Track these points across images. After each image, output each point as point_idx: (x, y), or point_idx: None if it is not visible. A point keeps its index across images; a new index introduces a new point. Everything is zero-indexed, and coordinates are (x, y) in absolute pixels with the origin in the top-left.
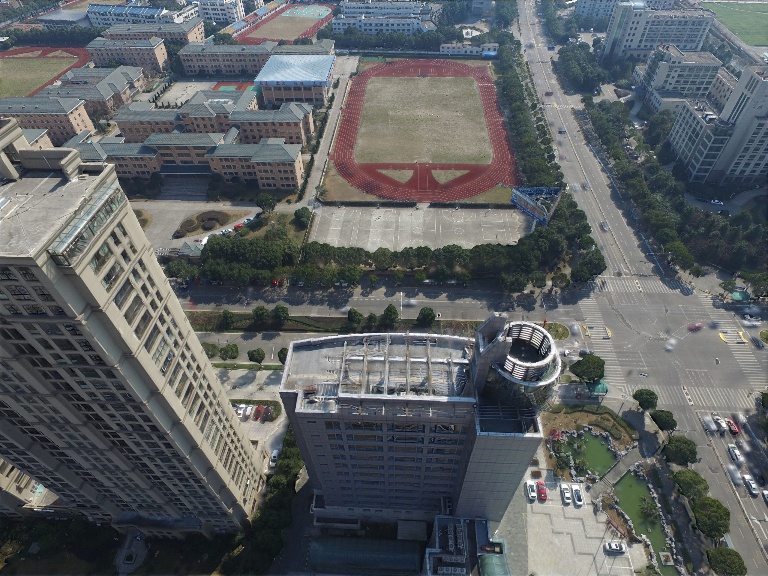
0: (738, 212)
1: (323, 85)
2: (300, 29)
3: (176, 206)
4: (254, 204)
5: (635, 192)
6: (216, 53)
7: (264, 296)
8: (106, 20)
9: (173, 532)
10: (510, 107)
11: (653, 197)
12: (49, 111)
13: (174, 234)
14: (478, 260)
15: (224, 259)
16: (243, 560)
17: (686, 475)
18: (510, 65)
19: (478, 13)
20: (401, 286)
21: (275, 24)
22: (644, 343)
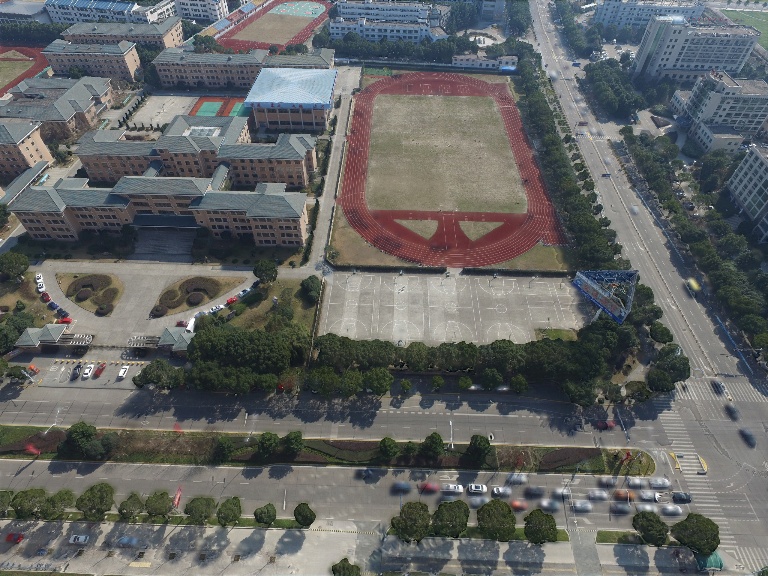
0: None
1: (325, 108)
2: (292, 30)
3: (154, 269)
4: (250, 267)
5: (704, 260)
6: (198, 63)
7: (269, 407)
8: (68, 14)
9: None
10: (541, 139)
11: (725, 267)
12: None
13: (152, 312)
14: (537, 364)
15: (217, 361)
16: None
17: None
18: (535, 85)
19: (488, 17)
20: (440, 392)
21: (263, 23)
22: (748, 480)
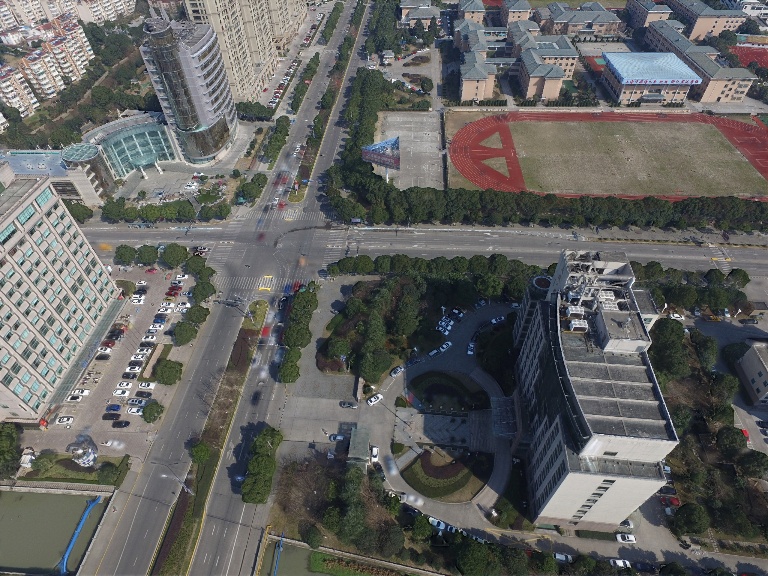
0: (453, 365)
1: None
2: None
3: (435, 70)
4: (440, 91)
5: None
6: (662, 34)
7: None
8: None
9: None
10: None
11: (456, 273)
12: (508, 5)
13: None
14: None
15: None
16: None
17: (172, 206)
18: None
19: None
20: None
21: None
22: (275, 234)
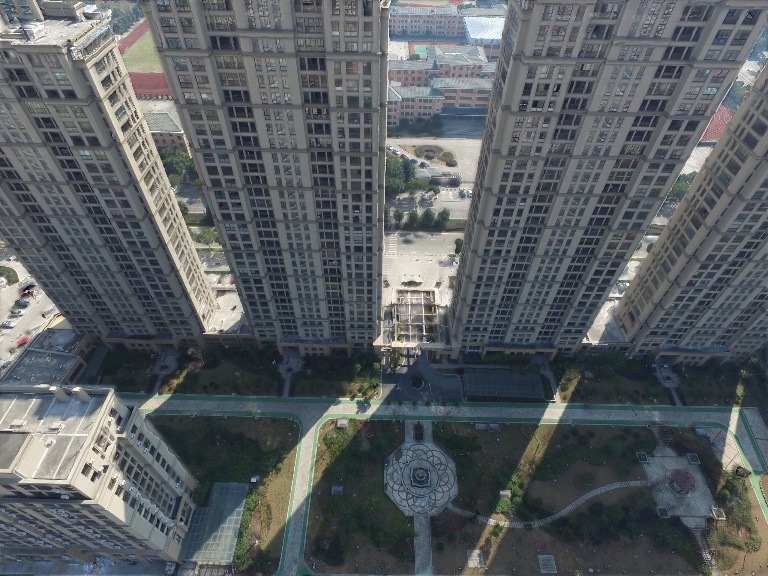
0: None
1: None
2: None
3: (466, 143)
4: None
5: None
6: (407, 14)
7: None
8: None
9: (706, 356)
10: None
11: None
12: None
13: None
14: None
15: None
16: (752, 378)
17: None
18: None
19: None
20: None
21: None
22: None
